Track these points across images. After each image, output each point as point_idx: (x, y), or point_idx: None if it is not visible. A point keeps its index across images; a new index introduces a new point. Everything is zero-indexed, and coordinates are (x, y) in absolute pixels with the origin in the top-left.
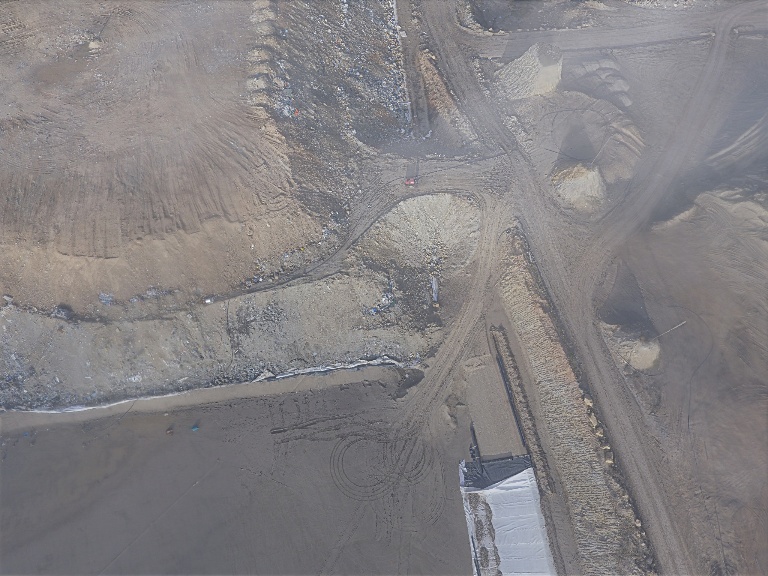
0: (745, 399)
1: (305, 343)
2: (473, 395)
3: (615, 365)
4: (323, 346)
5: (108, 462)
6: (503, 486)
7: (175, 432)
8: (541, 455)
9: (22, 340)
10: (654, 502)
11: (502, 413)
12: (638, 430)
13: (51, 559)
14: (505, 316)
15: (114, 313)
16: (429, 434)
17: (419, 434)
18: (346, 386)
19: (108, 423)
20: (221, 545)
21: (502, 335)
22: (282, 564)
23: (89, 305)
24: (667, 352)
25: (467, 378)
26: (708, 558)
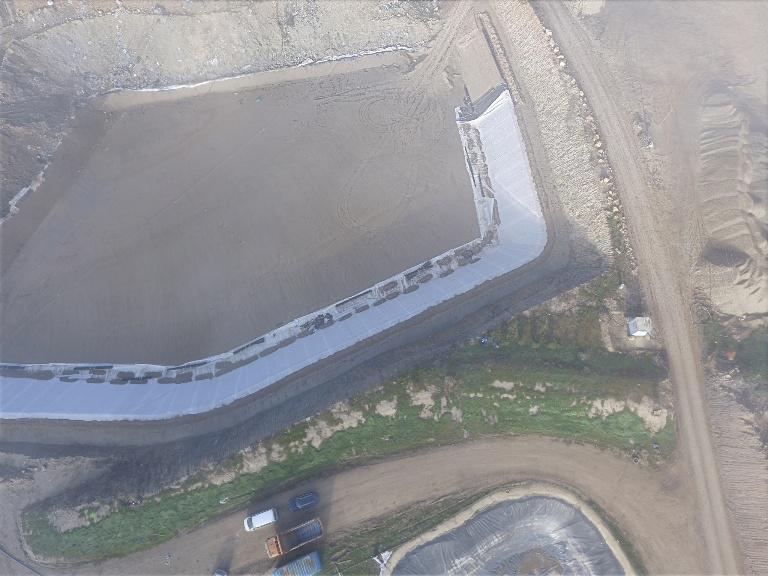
0: (670, 27)
1: (336, 33)
2: (465, 65)
3: (571, 15)
4: (350, 36)
5: (198, 122)
6: (488, 112)
7: (244, 103)
8: (515, 82)
9: (130, 37)
10: (595, 84)
11: (486, 64)
12: (586, 48)
13: (166, 174)
14: (489, 5)
15: (196, 8)
16: (432, 93)
17: (425, 93)
18: (369, 70)
19: (195, 101)
20: (283, 162)
21: (486, 15)
22: (328, 169)
23: (177, 4)
24: (612, 6)
25: (461, 55)
26: (632, 110)
